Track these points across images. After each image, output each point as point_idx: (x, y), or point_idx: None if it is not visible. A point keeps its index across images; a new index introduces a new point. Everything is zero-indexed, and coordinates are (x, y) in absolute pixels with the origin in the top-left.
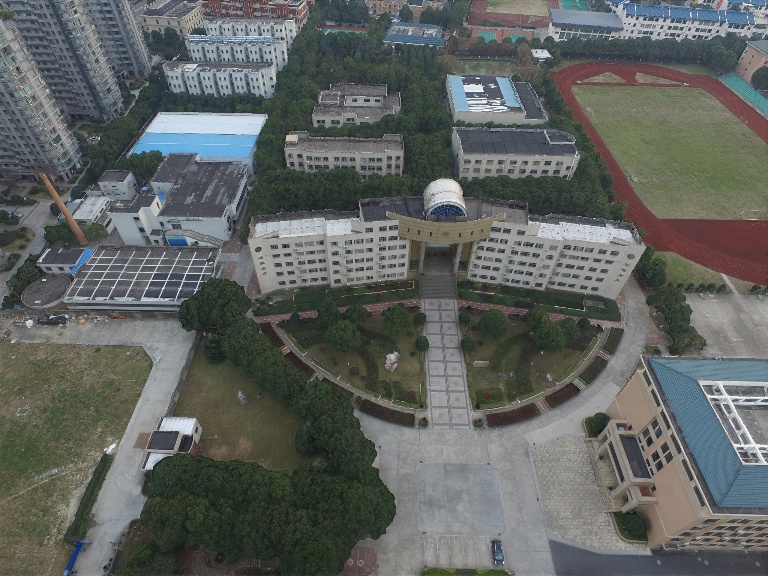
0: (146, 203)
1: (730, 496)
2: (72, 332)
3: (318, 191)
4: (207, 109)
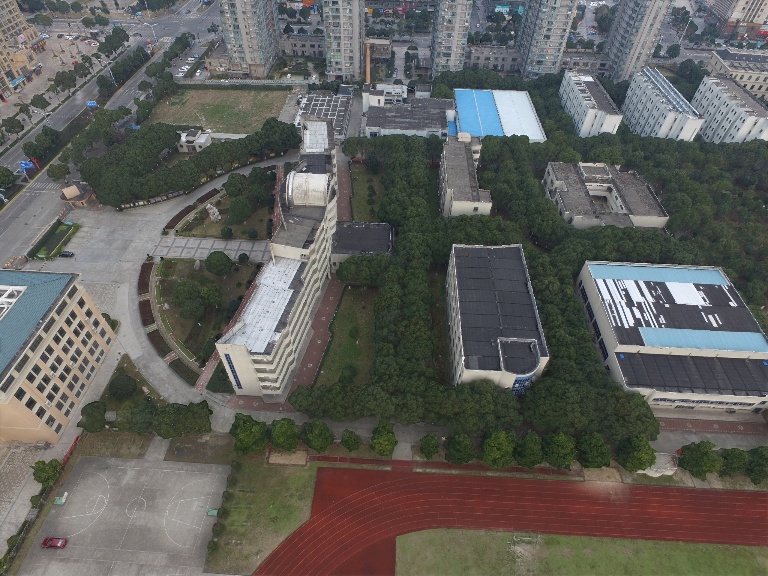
0: (375, 94)
1: None
2: (290, 109)
3: None
4: (542, 110)
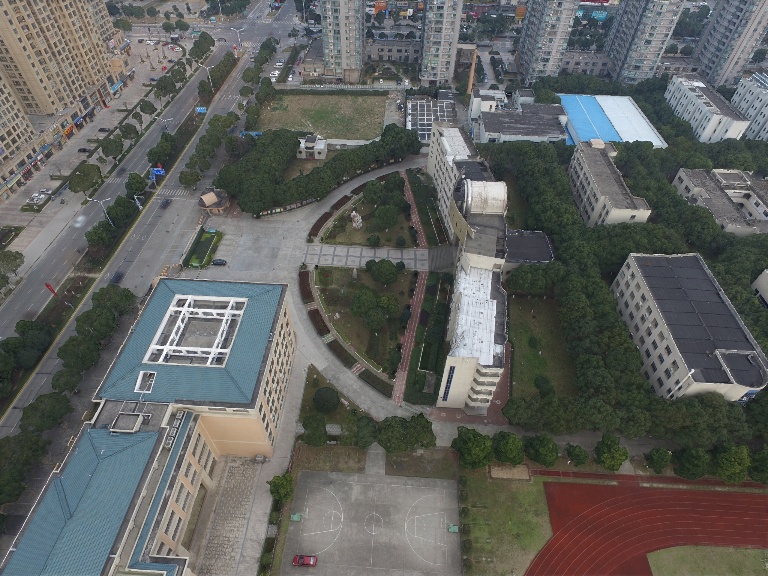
0: (487, 100)
1: (163, 286)
2: (393, 114)
3: (527, 166)
4: (652, 115)
